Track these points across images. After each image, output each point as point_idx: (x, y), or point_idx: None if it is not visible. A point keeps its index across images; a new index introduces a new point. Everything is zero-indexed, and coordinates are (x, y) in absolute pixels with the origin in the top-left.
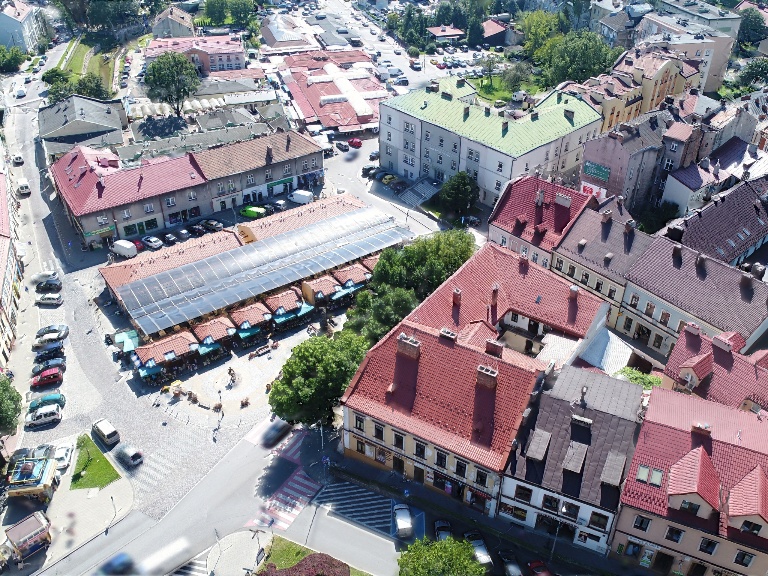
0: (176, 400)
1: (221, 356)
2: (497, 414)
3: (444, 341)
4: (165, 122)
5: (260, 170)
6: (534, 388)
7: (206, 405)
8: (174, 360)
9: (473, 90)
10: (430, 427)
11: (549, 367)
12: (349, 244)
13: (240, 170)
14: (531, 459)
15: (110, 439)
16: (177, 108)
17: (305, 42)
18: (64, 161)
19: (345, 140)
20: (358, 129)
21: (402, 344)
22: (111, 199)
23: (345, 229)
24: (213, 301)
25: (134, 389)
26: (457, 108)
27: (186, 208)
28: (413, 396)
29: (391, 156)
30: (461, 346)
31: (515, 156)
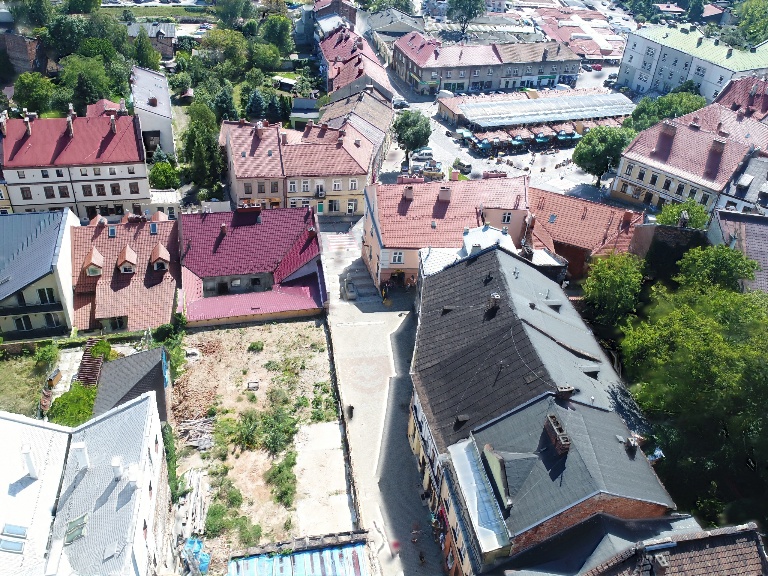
0: (499, 163)
1: (523, 150)
2: (721, 165)
3: (692, 128)
4: (458, 33)
5: (537, 64)
6: (747, 153)
7: (519, 167)
8: (495, 146)
9: (702, 35)
10: (677, 170)
11: (757, 148)
12: (605, 110)
13: (525, 61)
14: (739, 187)
15: (467, 169)
16: (464, 27)
17: (551, 1)
18: (405, 39)
19: (589, 64)
20: (600, 58)
21: (666, 126)
22: (443, 62)
23: (601, 102)
24: (520, 120)
25: (472, 155)
26: (692, 39)
27: (484, 80)
28: (668, 154)
29: (629, 74)
30: (703, 131)
31: (735, 71)
